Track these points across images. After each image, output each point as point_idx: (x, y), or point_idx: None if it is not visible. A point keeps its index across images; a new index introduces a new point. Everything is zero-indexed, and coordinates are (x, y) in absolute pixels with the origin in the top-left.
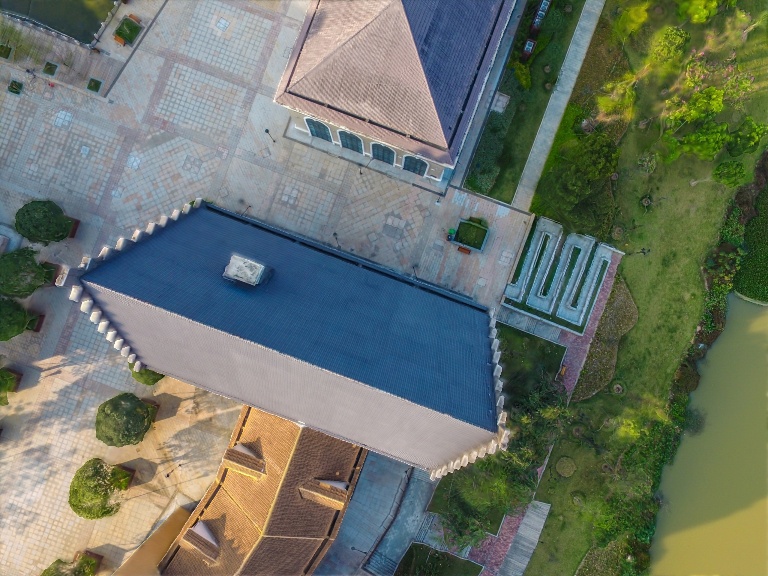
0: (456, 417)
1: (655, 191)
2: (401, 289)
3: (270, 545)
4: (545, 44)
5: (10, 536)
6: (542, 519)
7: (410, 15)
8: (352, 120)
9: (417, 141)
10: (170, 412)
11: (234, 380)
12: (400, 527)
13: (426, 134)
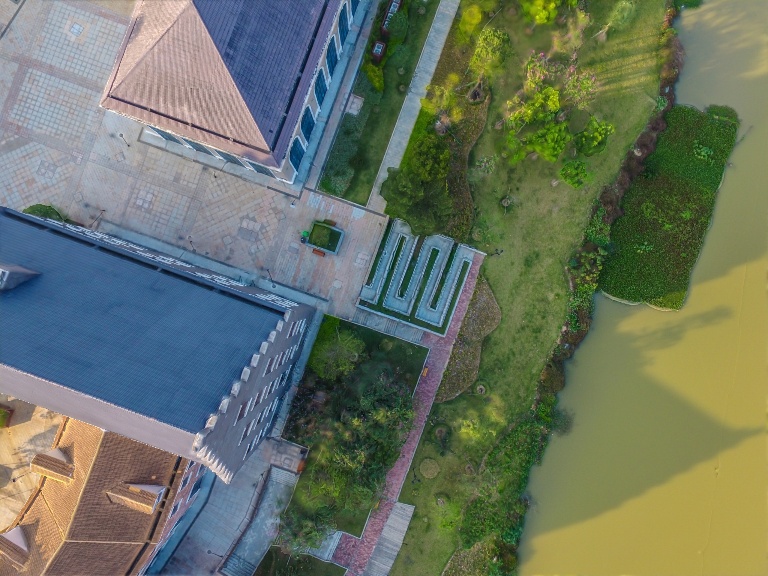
0: (164, 421)
1: (515, 192)
2: (192, 293)
3: (76, 550)
4: None
5: None
6: (406, 521)
7: (207, 19)
8: (176, 124)
9: (241, 144)
10: (25, 417)
11: (4, 385)
12: (259, 530)
13: (247, 137)
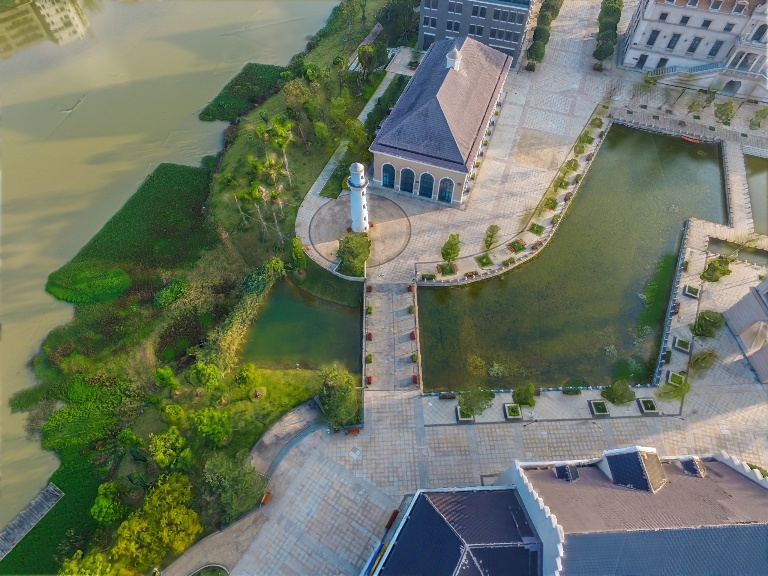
0: None
1: None
2: None
3: None
4: None
5: (585, 5)
6: None
7: None
8: None
9: None
10: None
11: None
12: None
13: None
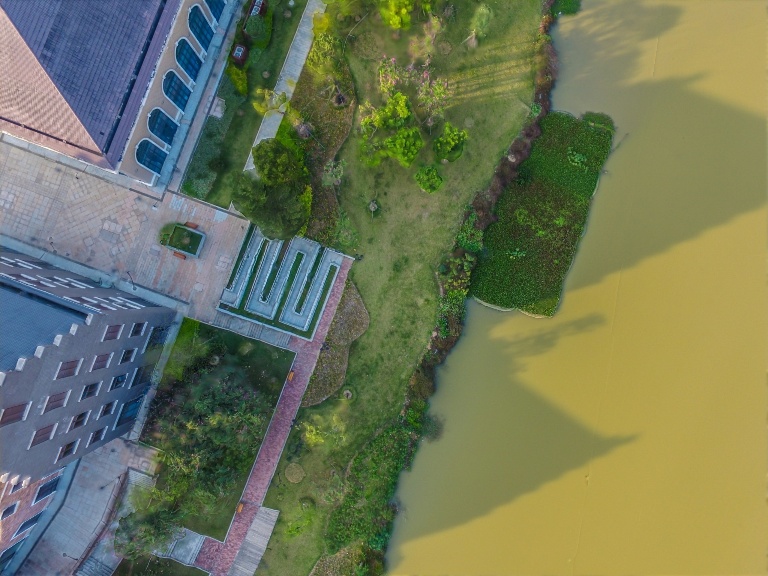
0: None
1: (383, 196)
2: None
3: None
4: (262, 49)
5: None
6: (270, 525)
7: (17, 21)
8: (9, 125)
9: (74, 146)
10: None
11: None
12: None
13: (78, 139)
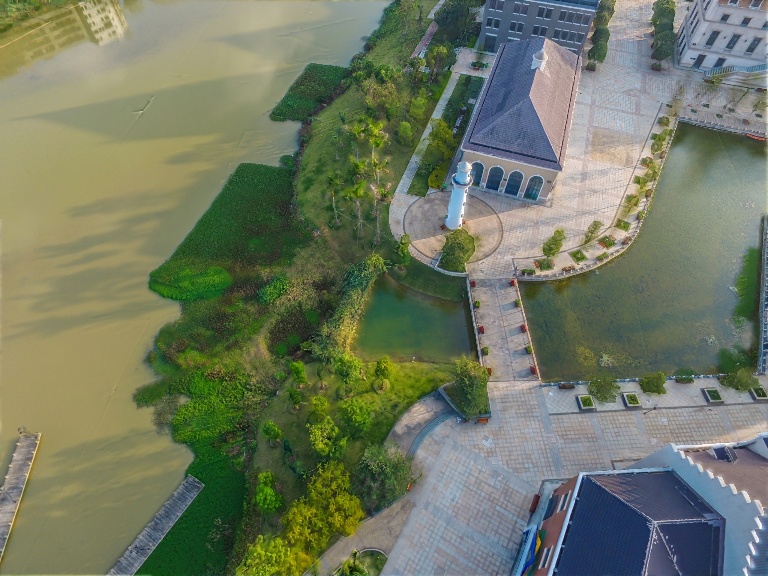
0: None
1: None
2: None
3: None
4: None
5: (633, 6)
6: (430, 15)
7: None
8: None
9: None
10: None
11: None
12: None
13: None
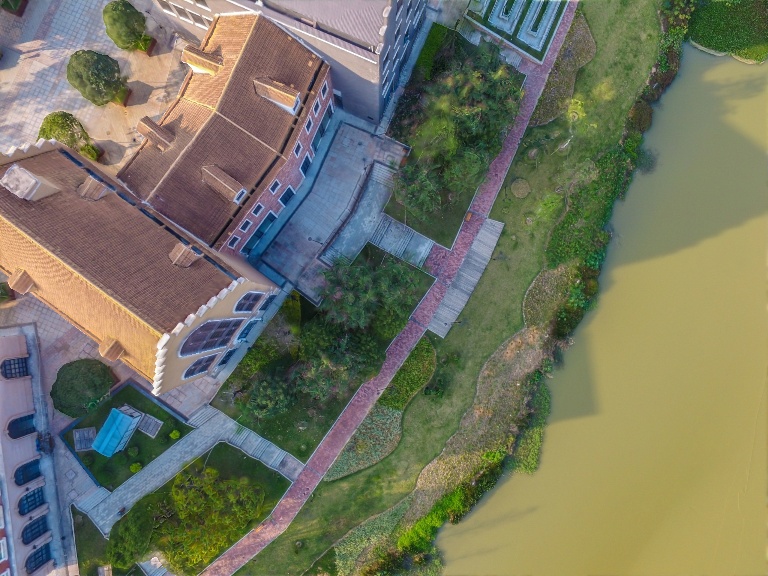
0: None
1: None
2: None
3: (222, 128)
4: None
5: None
6: (495, 237)
7: None
8: None
9: None
10: (142, 99)
11: None
12: (357, 226)
13: None
